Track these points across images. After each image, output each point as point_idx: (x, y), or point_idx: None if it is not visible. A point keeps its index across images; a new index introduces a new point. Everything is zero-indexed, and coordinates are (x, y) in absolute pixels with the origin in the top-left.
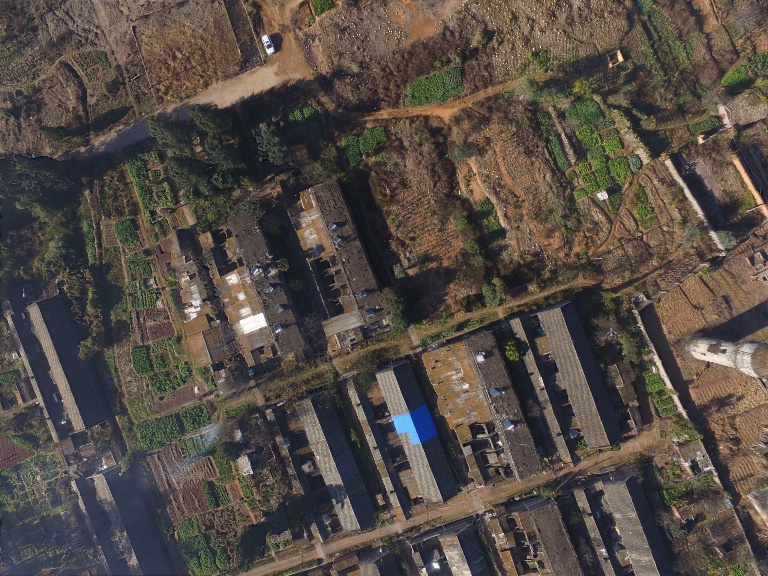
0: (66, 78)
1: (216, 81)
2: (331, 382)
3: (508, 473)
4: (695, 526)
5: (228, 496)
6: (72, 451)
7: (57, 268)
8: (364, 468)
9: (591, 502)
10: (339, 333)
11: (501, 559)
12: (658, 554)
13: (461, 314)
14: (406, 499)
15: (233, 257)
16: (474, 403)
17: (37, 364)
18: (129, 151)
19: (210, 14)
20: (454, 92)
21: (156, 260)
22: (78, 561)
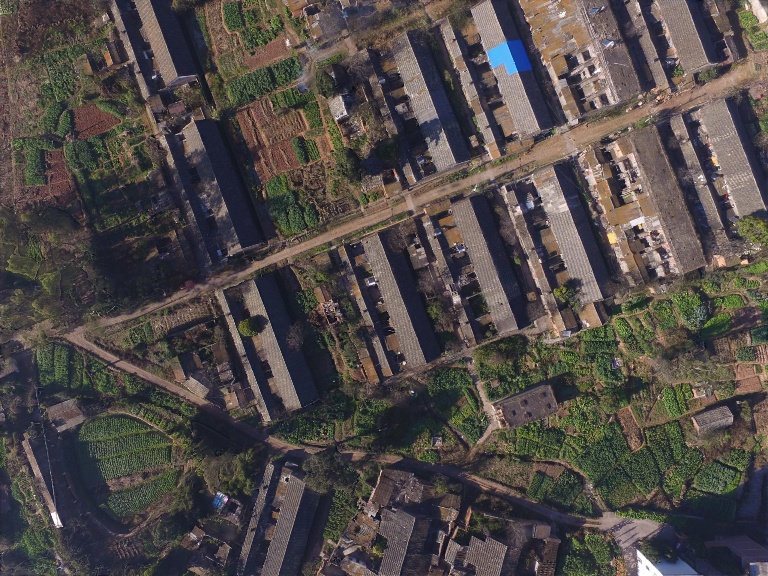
0: None
1: None
2: None
3: (604, 103)
4: None
5: (318, 151)
6: (161, 109)
7: None
8: (456, 114)
9: (688, 129)
10: None
11: (595, 201)
12: (757, 176)
13: None
14: (500, 137)
15: None
16: (571, 28)
17: (128, 21)
18: None
19: None
20: None
21: None
22: (163, 227)
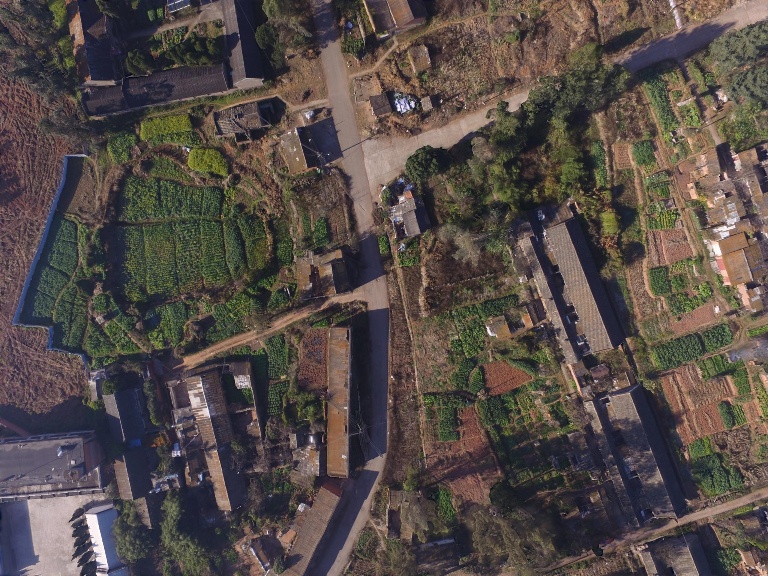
0: None
1: (740, 0)
2: None
3: None
4: None
5: (744, 415)
6: (584, 373)
7: (572, 190)
8: None
9: None
10: None
11: None
12: None
13: None
14: None
15: None
16: None
17: (553, 286)
18: (649, 72)
19: None
20: None
21: (675, 181)
22: (578, 483)
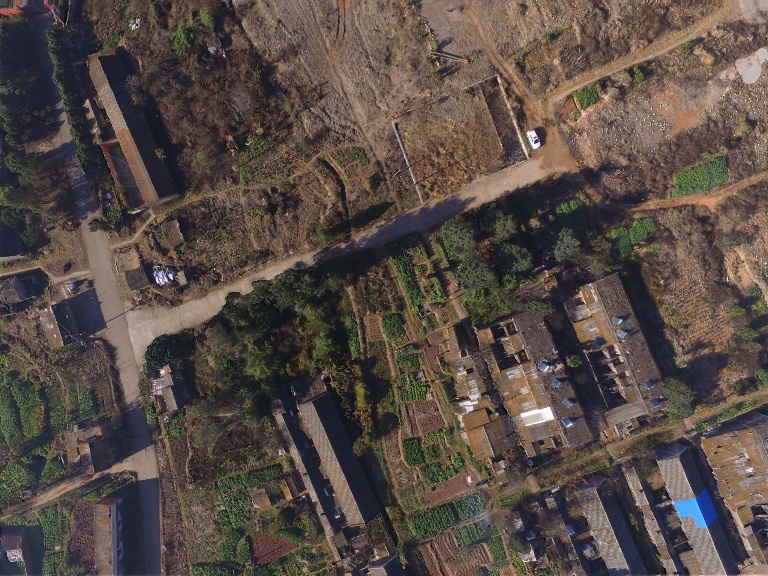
0: (325, 175)
1: (480, 175)
2: (606, 468)
3: None
4: None
5: None
6: (344, 544)
7: (324, 365)
8: (639, 549)
9: None
10: None
11: None
12: None
13: (734, 398)
14: None
15: (510, 351)
16: (760, 487)
17: (308, 460)
18: (394, 247)
19: (471, 109)
20: (719, 181)
21: (424, 353)
22: None
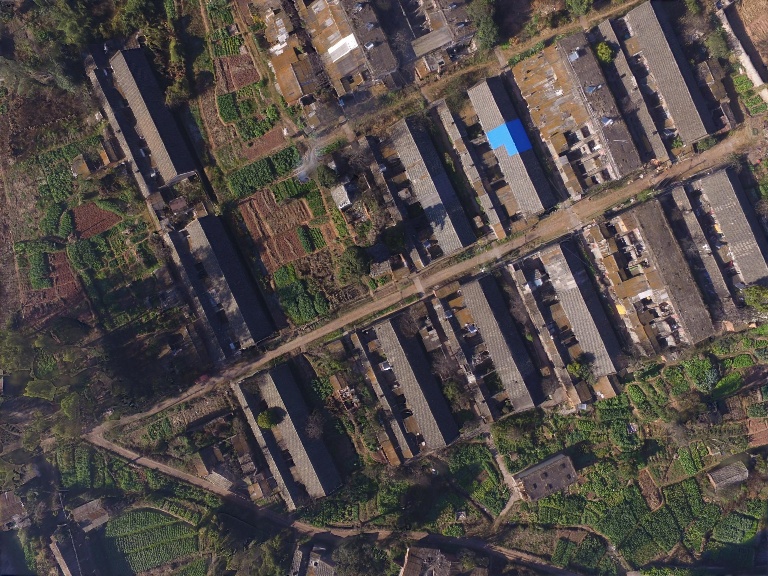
0: None
1: None
2: None
3: (606, 178)
4: None
5: (323, 238)
6: (162, 206)
7: (137, 22)
8: (459, 194)
9: (690, 199)
10: (427, 56)
11: (602, 273)
12: (761, 243)
13: (547, 31)
14: (505, 216)
15: None
16: (569, 106)
17: (122, 119)
18: None
19: None
20: None
21: (237, 6)
22: (173, 322)
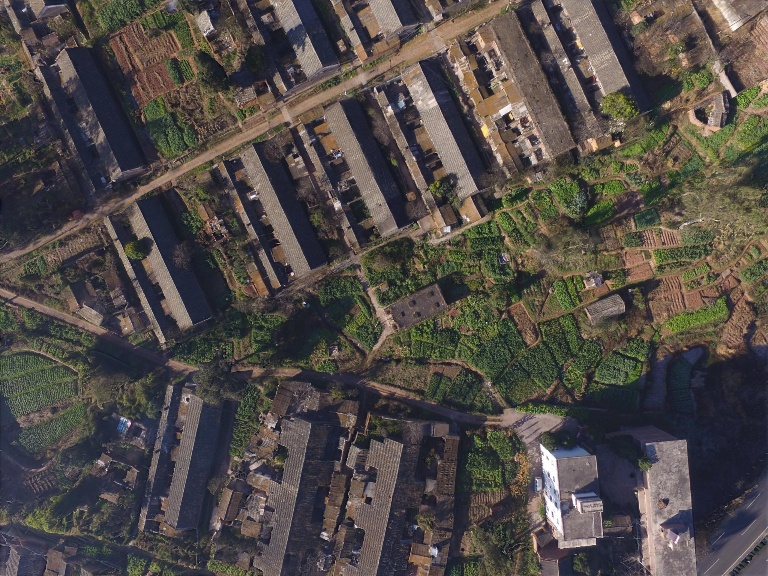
0: None
1: None
2: None
3: None
4: (654, 22)
5: (192, 70)
6: (35, 41)
7: None
8: (324, 21)
9: (549, 13)
10: None
11: (466, 95)
12: (620, 53)
13: None
14: (366, 38)
15: None
16: None
17: None
18: None
19: None
20: None
21: None
22: (48, 160)
